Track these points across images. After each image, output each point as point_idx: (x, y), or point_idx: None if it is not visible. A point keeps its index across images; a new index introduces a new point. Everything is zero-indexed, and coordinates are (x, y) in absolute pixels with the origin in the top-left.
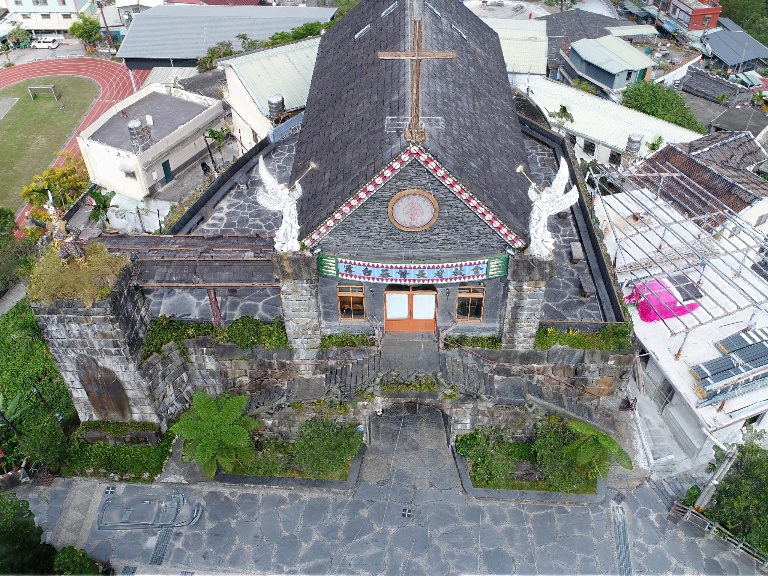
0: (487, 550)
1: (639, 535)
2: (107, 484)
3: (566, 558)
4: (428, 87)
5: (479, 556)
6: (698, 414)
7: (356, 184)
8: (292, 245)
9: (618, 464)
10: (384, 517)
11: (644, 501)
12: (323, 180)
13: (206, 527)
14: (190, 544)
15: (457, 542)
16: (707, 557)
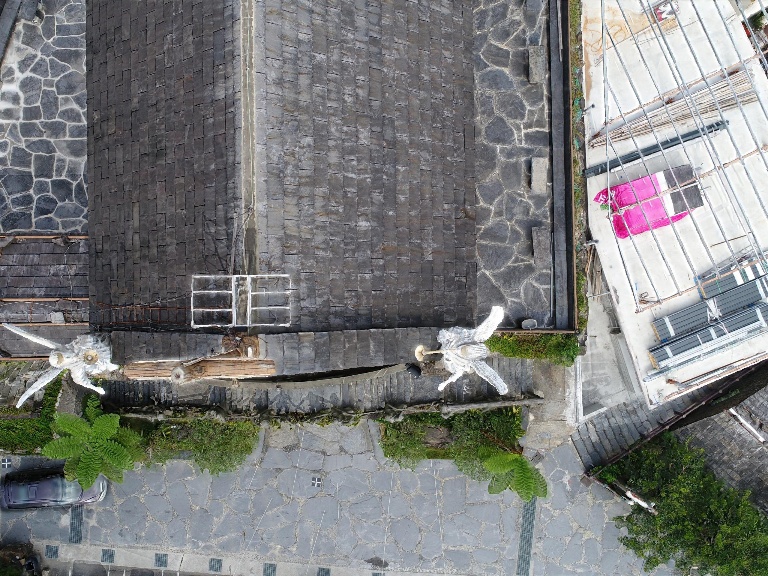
0: (395, 521)
1: (548, 500)
2: (1, 456)
3: (471, 527)
4: (280, 53)
5: (387, 527)
6: (643, 387)
7: (168, 357)
8: (106, 366)
9: (544, 420)
10: (293, 487)
11: (562, 462)
12: (131, 221)
13: (115, 503)
14: (104, 521)
15: (366, 513)
16: (609, 521)
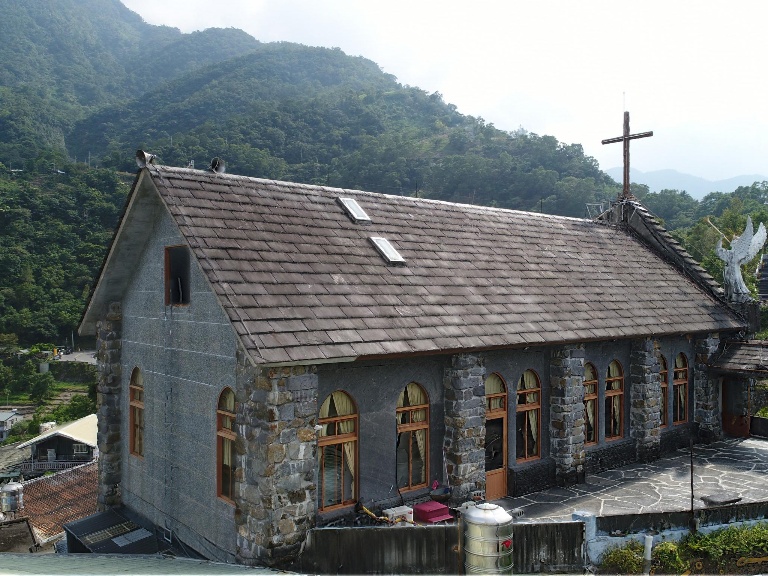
0: None
1: None
2: None
3: None
4: None
5: None
6: None
7: None
8: None
9: None
10: None
11: None
12: None
13: None
14: None
15: None
16: None
